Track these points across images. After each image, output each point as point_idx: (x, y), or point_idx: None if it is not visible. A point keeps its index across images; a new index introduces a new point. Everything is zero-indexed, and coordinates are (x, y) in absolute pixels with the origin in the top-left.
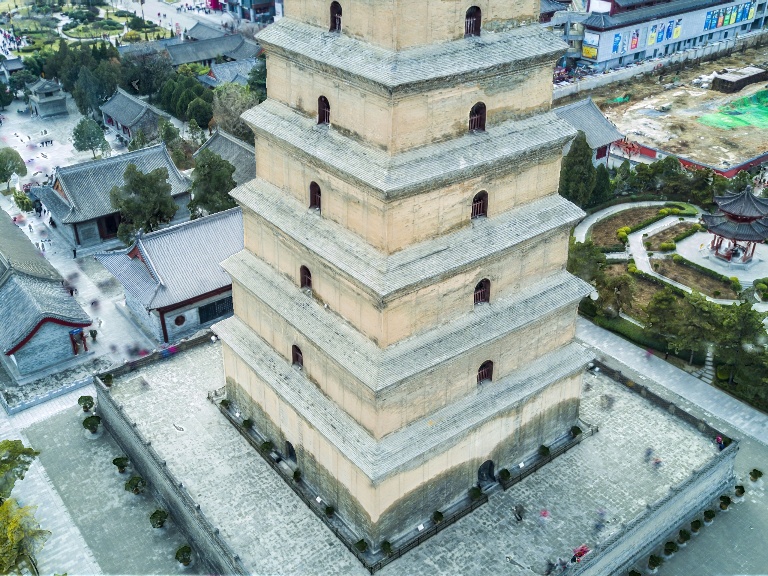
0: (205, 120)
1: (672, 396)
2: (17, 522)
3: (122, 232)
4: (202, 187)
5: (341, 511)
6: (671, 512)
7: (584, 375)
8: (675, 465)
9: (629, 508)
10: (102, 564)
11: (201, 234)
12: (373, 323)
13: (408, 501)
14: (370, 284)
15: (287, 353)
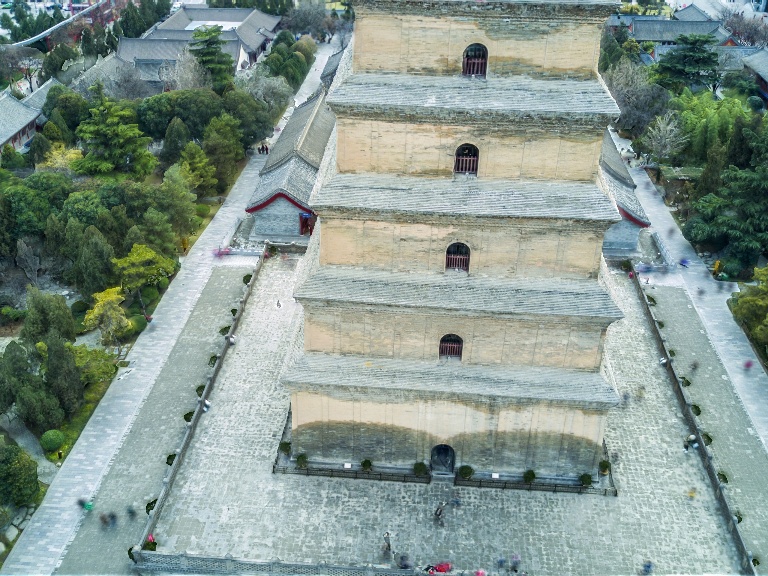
0: None
1: None
2: (104, 301)
3: None
4: None
5: None
6: None
7: (674, 443)
8: (662, 575)
9: (554, 574)
10: (163, 371)
11: None
12: None
13: (334, 430)
14: None
15: None
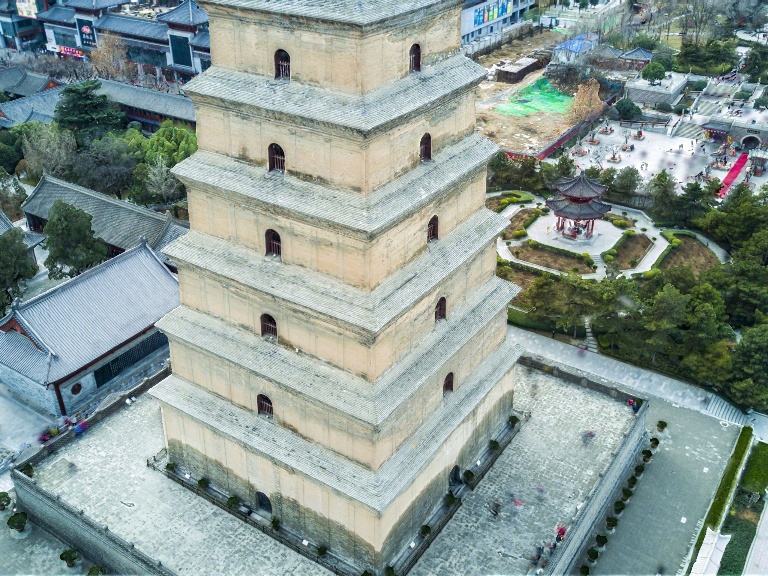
0: (10, 165)
1: (570, 370)
2: None
3: None
4: (60, 242)
5: (334, 548)
6: (613, 475)
7: None
8: (604, 432)
9: (582, 480)
10: None
11: (81, 293)
12: (360, 360)
13: (402, 523)
14: (360, 323)
15: (250, 404)
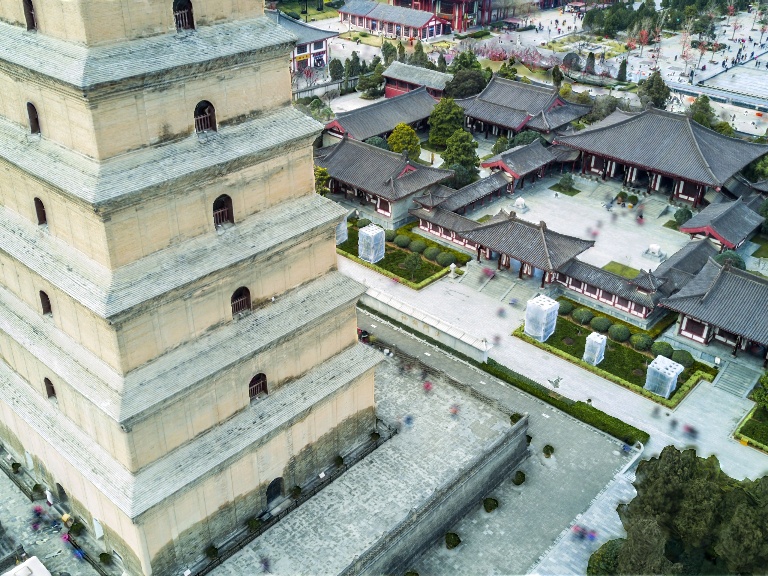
0: None
1: None
2: None
3: None
4: None
5: None
6: None
7: None
8: None
9: None
10: None
11: None
12: None
13: None
14: (336, 215)
15: None
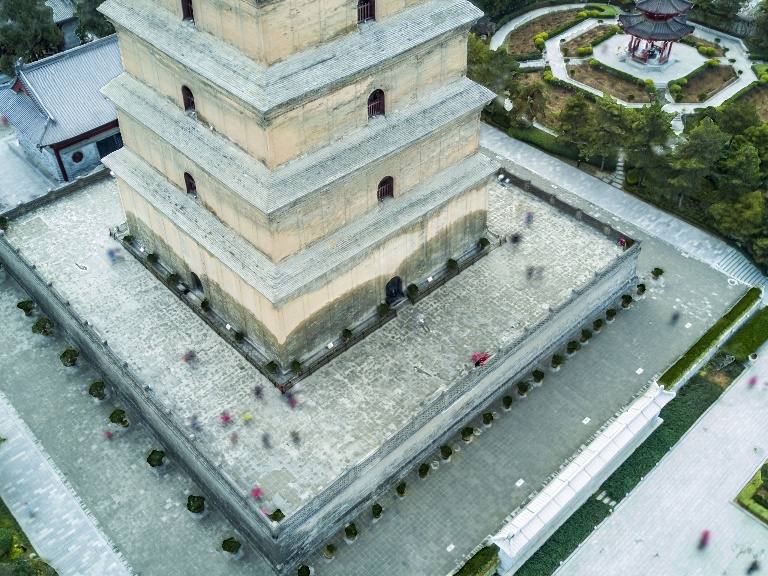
0: None
1: (582, 203)
2: None
3: (5, 65)
4: (88, 9)
5: (250, 336)
6: (574, 313)
7: (494, 187)
8: (579, 269)
9: (533, 312)
10: (16, 405)
11: (89, 62)
12: (259, 143)
13: (315, 321)
14: (250, 100)
15: (180, 182)
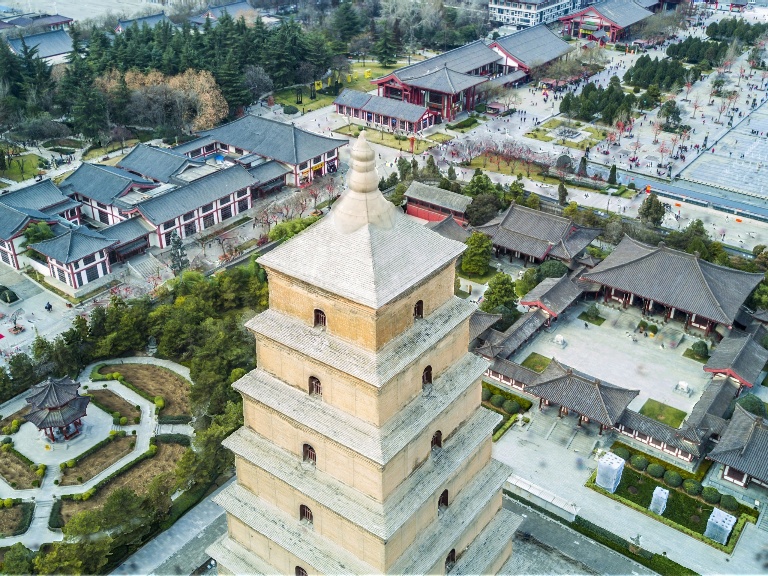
0: None
1: None
2: None
3: None
4: None
5: None
6: None
7: None
8: None
9: None
10: None
11: None
12: None
13: None
14: None
15: None
